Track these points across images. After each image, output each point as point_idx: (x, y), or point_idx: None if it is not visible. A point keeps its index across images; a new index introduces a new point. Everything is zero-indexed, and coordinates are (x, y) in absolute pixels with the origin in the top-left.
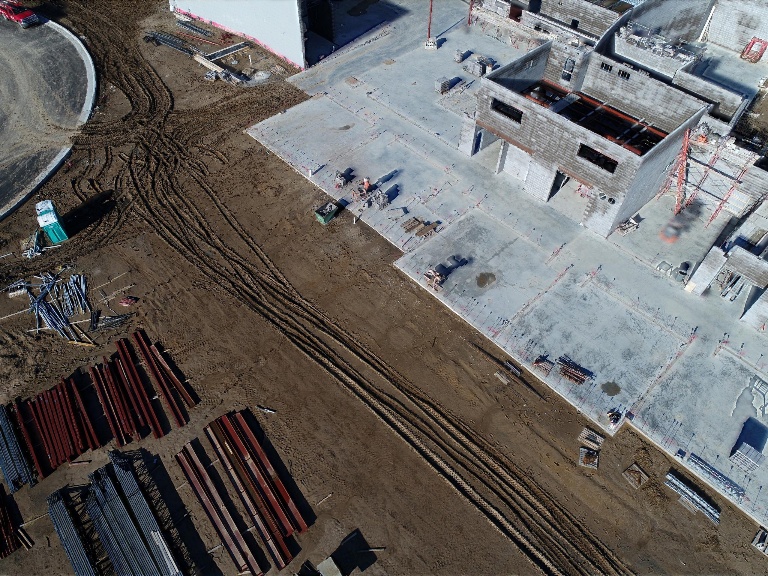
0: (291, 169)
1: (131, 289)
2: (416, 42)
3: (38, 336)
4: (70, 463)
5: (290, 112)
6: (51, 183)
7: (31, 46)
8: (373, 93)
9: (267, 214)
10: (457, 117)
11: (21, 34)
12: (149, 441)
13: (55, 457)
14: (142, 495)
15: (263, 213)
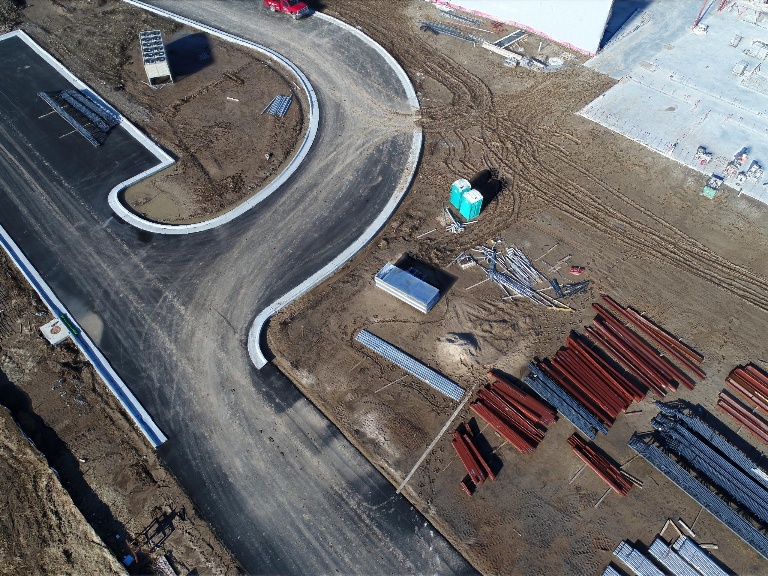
0: (645, 148)
1: (571, 259)
2: (681, 28)
3: (515, 303)
4: (625, 413)
5: (609, 95)
6: (425, 165)
7: (315, 36)
8: (674, 76)
9: (650, 189)
10: (767, 98)
11: (297, 25)
12: (683, 393)
13: (612, 408)
14: (721, 438)
15: (646, 189)
